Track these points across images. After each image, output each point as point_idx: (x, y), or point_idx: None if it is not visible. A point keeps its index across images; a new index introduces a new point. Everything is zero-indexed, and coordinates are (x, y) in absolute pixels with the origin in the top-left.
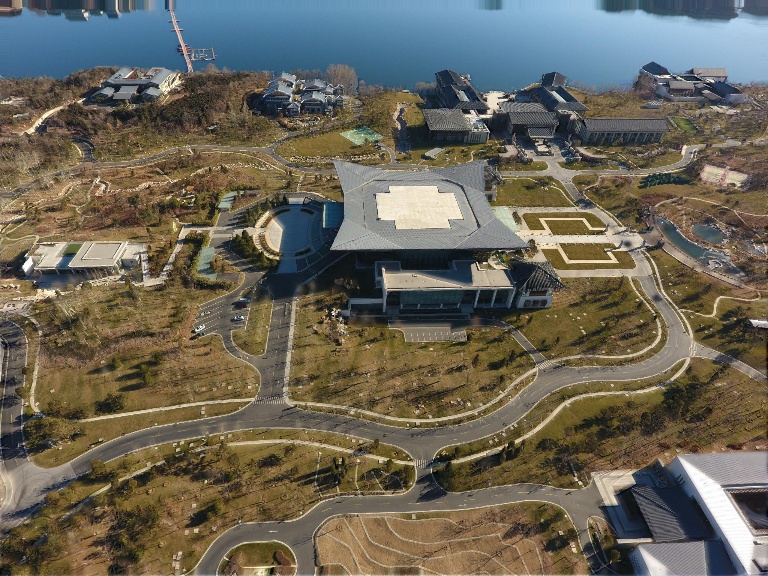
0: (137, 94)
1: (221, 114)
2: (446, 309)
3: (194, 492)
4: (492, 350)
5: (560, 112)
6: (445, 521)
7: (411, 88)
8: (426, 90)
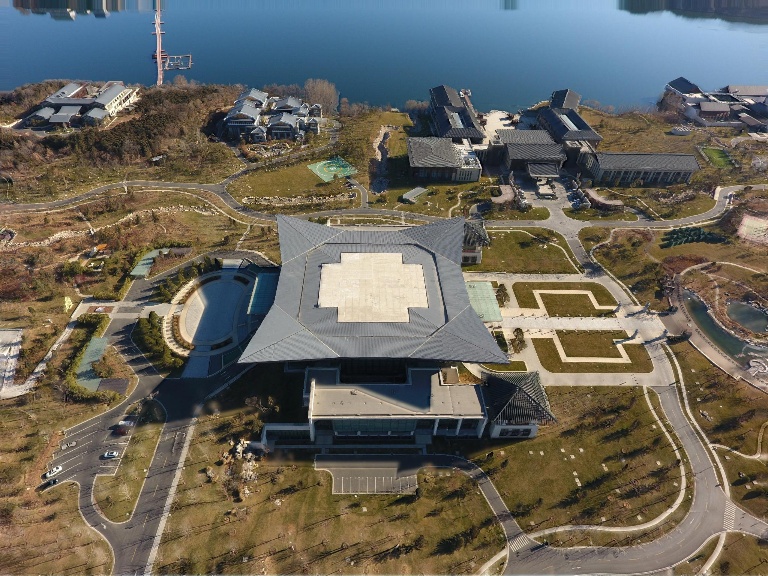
0: (79, 116)
1: (173, 140)
2: (395, 437)
3: None
4: (448, 514)
5: (568, 144)
6: None
7: (401, 107)
8: (417, 109)
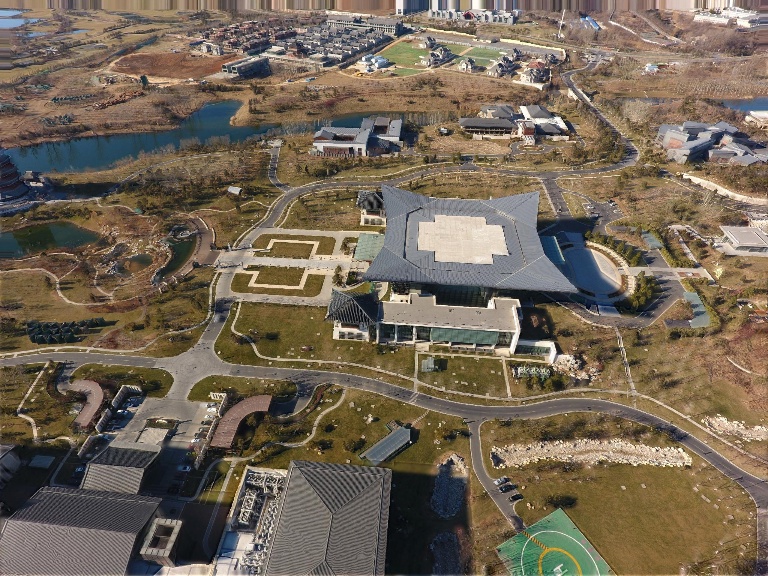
0: None
1: None
2: None
3: (565, 157)
4: None
5: None
6: (463, 152)
7: None
8: None
